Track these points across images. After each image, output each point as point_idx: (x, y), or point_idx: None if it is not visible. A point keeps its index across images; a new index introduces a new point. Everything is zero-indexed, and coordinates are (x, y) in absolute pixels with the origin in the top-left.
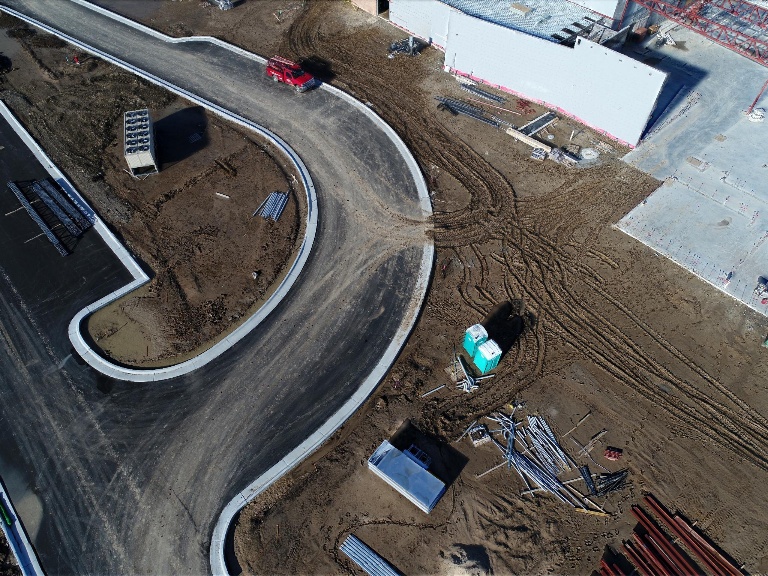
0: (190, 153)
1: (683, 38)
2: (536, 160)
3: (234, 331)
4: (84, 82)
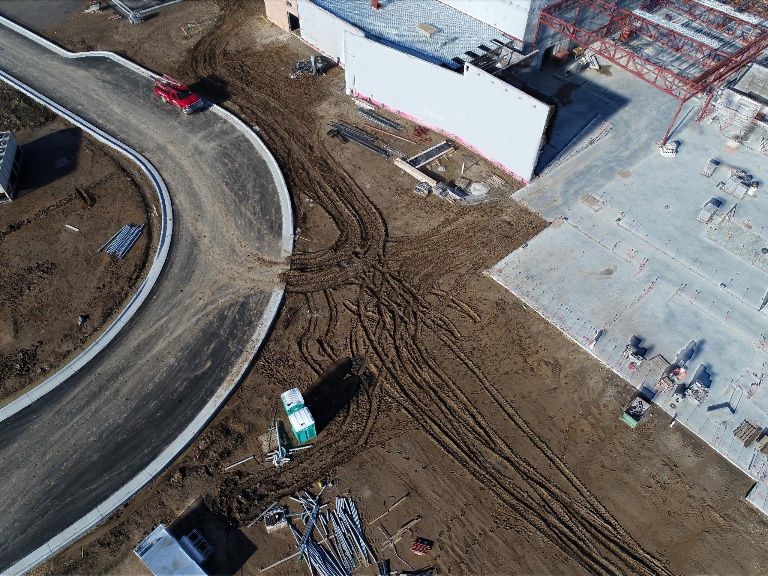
0: (52, 179)
1: (609, 62)
2: (419, 195)
3: (38, 386)
4: None
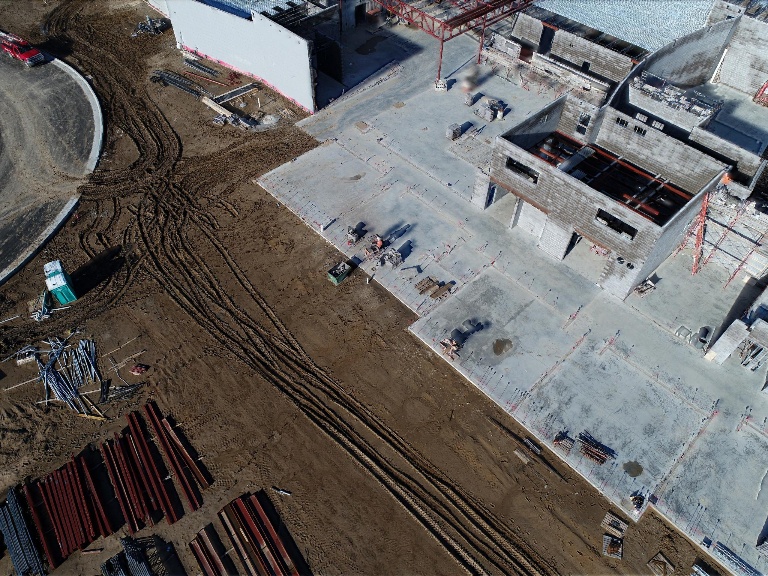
0: None
1: (419, 19)
2: (217, 125)
3: None
4: None
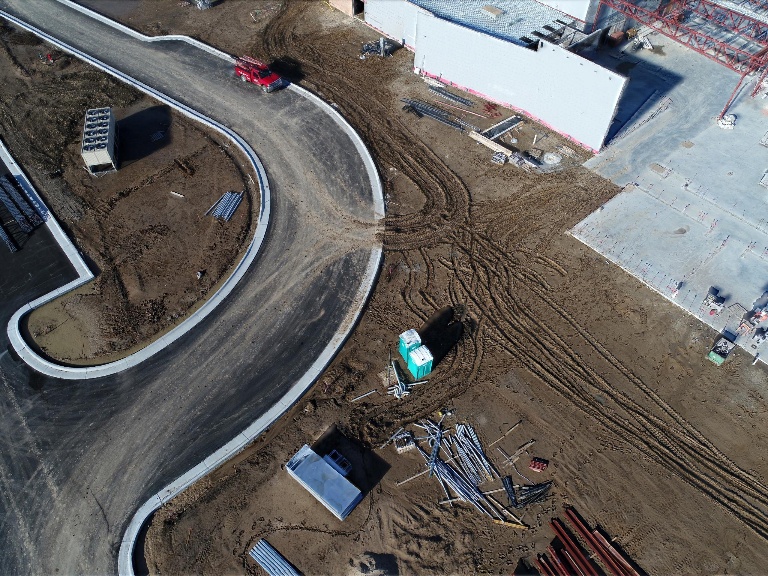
0: (150, 151)
1: (661, 42)
2: (496, 164)
3: (171, 331)
4: (55, 79)
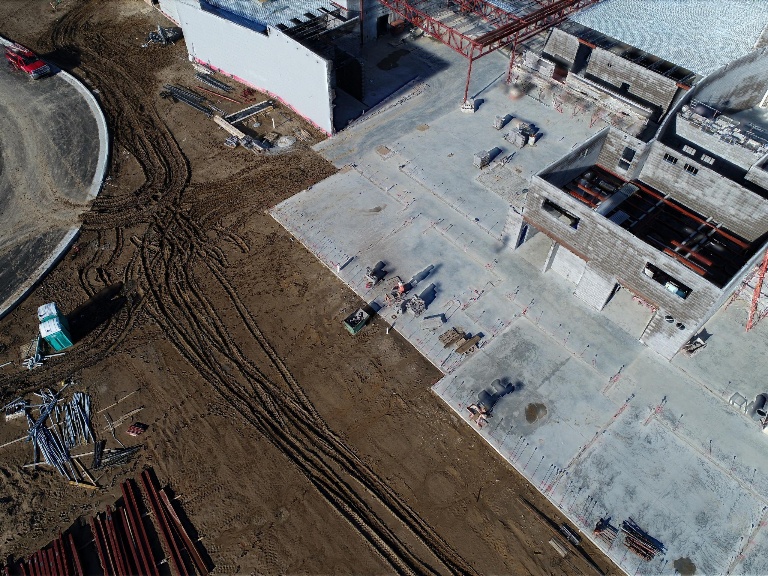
0: None
1: None
2: (229, 147)
3: None
4: None
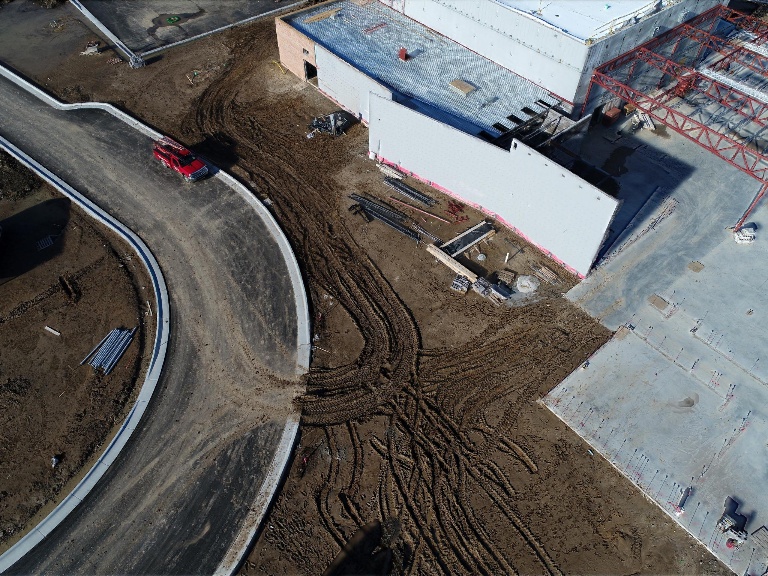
0: (33, 265)
1: None
2: (457, 292)
3: None
4: None
